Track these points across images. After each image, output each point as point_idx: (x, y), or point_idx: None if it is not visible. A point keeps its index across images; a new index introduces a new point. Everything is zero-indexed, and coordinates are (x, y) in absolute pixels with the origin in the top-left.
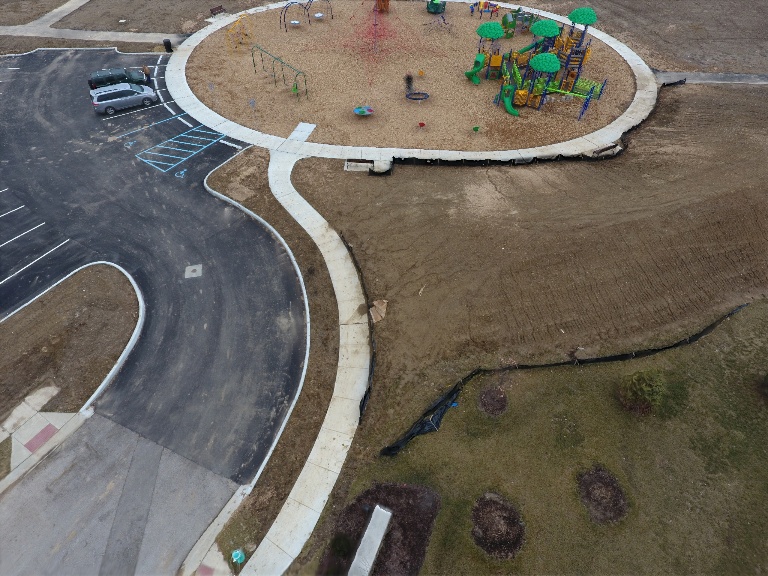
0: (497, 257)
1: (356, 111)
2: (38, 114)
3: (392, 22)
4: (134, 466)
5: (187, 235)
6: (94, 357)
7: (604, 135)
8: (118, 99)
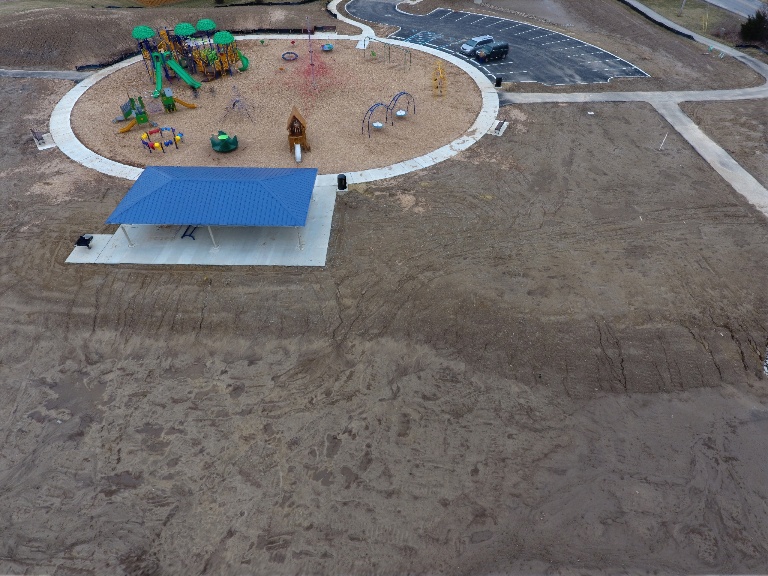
0: (282, 7)
1: (331, 45)
2: (523, 47)
3: None
4: (382, 0)
5: None
6: (404, 5)
7: None
8: None
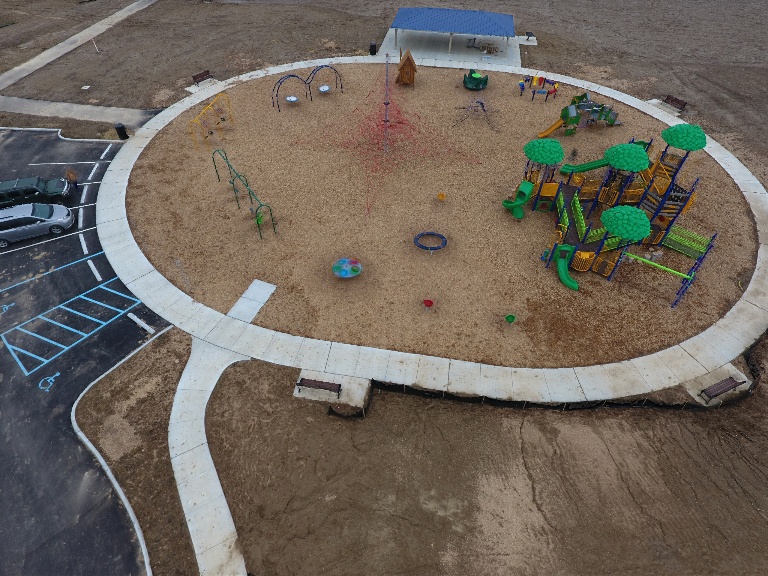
0: None
1: (335, 269)
2: None
3: (416, 101)
4: None
5: (2, 539)
6: None
7: (715, 343)
8: (12, 229)
